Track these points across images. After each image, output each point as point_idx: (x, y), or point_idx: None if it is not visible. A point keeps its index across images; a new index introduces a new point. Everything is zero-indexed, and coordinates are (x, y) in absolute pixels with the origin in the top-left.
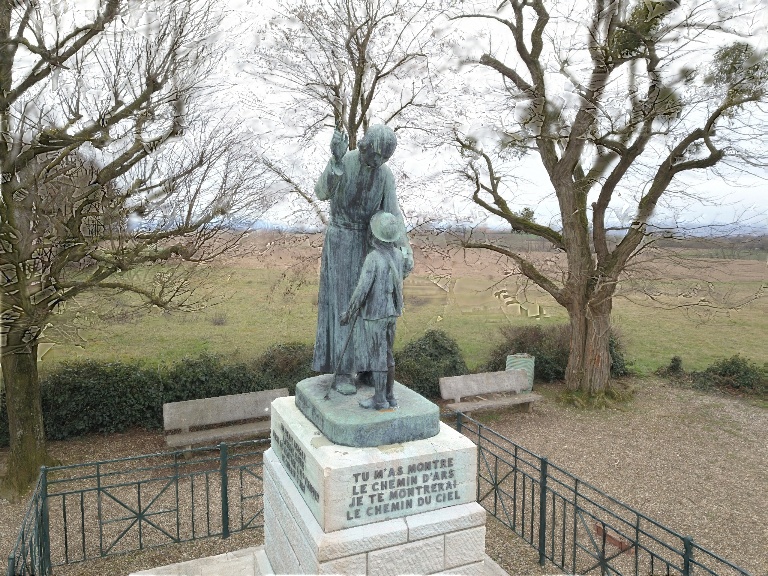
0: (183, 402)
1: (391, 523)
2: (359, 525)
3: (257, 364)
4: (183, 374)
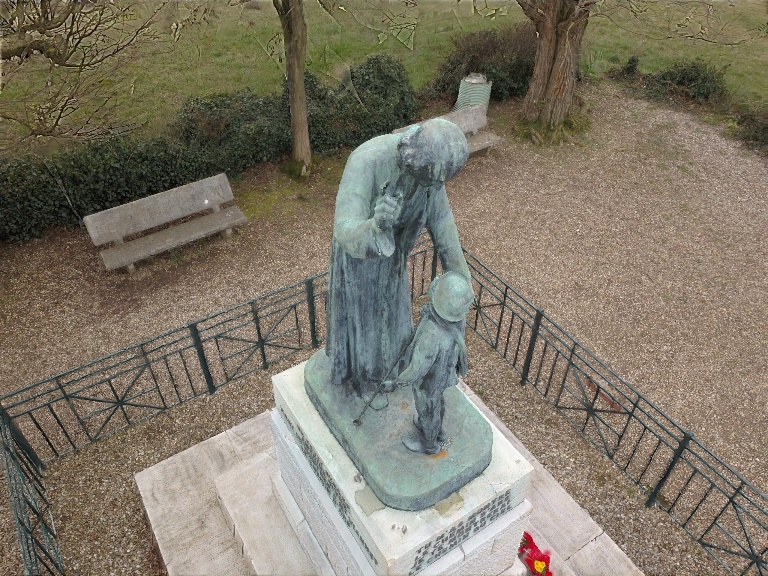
0: (106, 212)
1: (449, 557)
2: (419, 572)
3: (176, 131)
4: (90, 164)
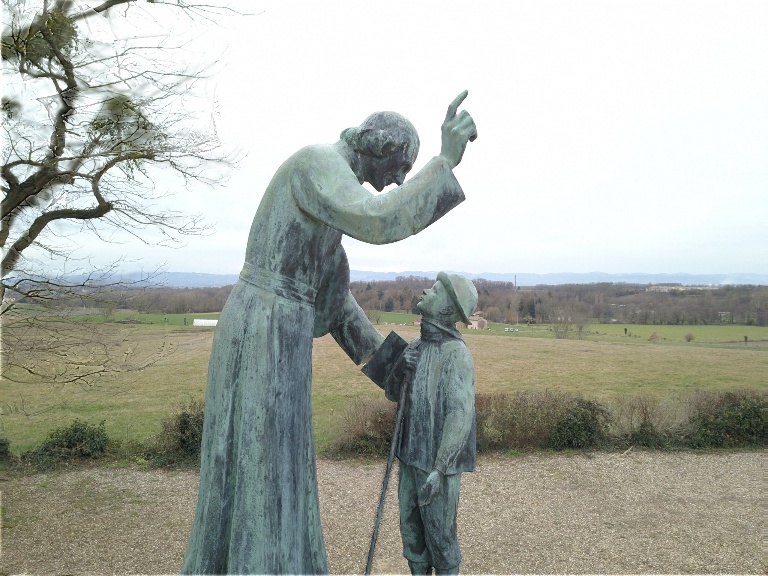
0: None
1: None
2: None
3: None
4: None
